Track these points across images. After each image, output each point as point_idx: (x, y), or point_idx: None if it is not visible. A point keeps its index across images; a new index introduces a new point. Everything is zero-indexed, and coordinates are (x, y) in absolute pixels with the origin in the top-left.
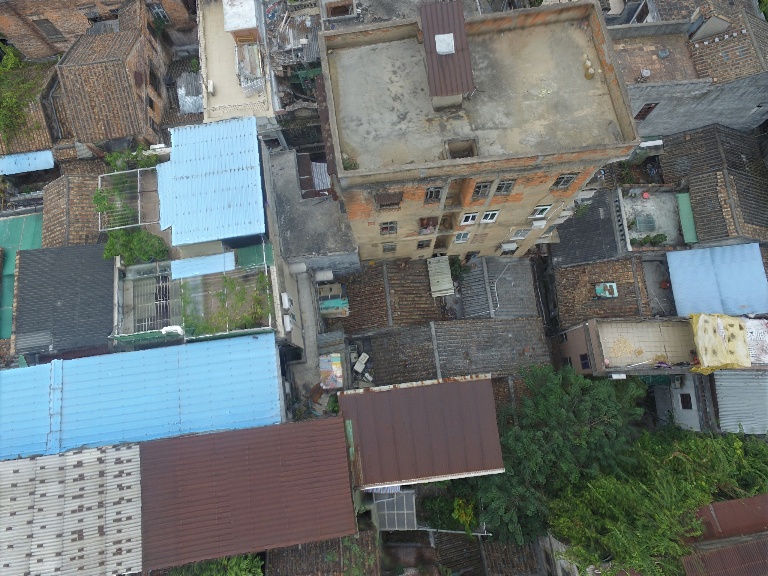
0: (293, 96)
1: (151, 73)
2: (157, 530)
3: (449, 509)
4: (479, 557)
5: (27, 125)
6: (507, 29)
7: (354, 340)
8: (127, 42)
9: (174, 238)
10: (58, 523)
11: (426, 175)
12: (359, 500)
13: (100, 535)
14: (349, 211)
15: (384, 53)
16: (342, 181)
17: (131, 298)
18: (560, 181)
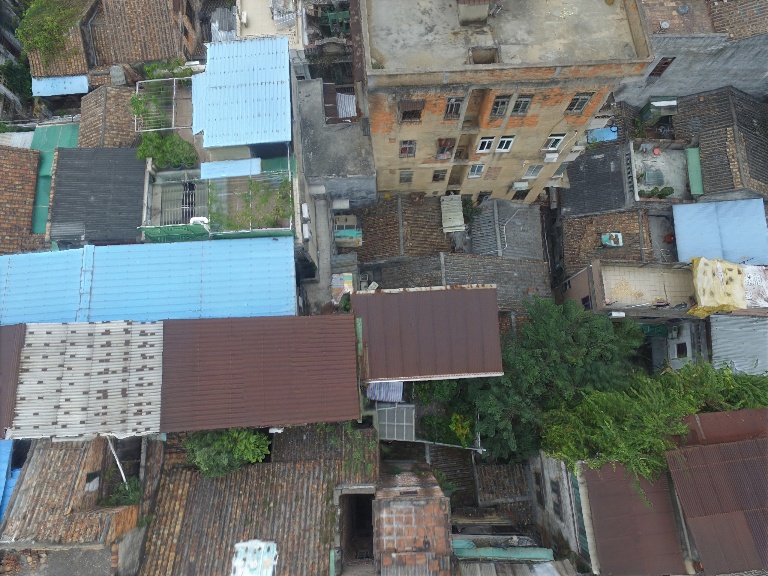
0: (321, 38)
1: (188, 4)
2: (175, 397)
3: (446, 426)
4: (472, 479)
5: (65, 49)
6: None
7: (365, 269)
8: None
9: (205, 141)
10: (85, 382)
11: (449, 81)
12: (362, 405)
13: (123, 396)
14: (373, 121)
15: None
16: (370, 81)
17: (159, 202)
18: (575, 103)
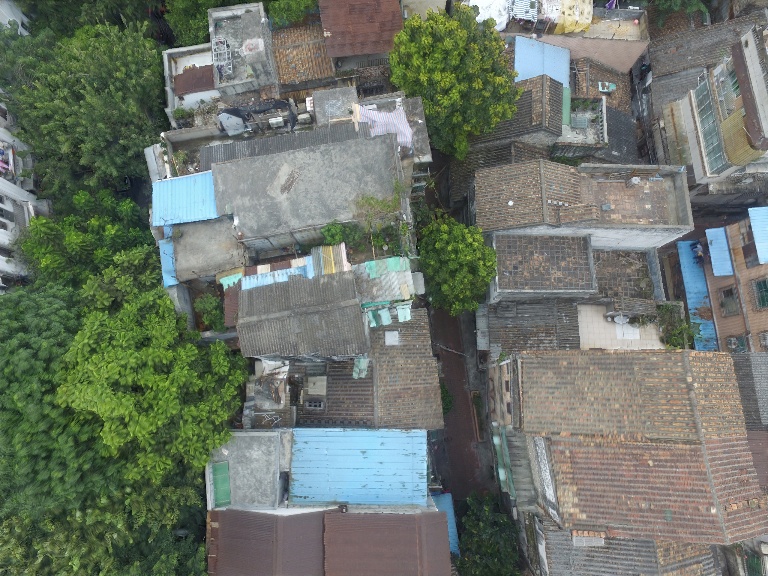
0: None
1: None
2: None
3: None
4: None
5: None
6: None
7: None
8: None
9: None
10: None
11: None
12: None
13: None
14: None
15: None
16: None
17: None
18: None
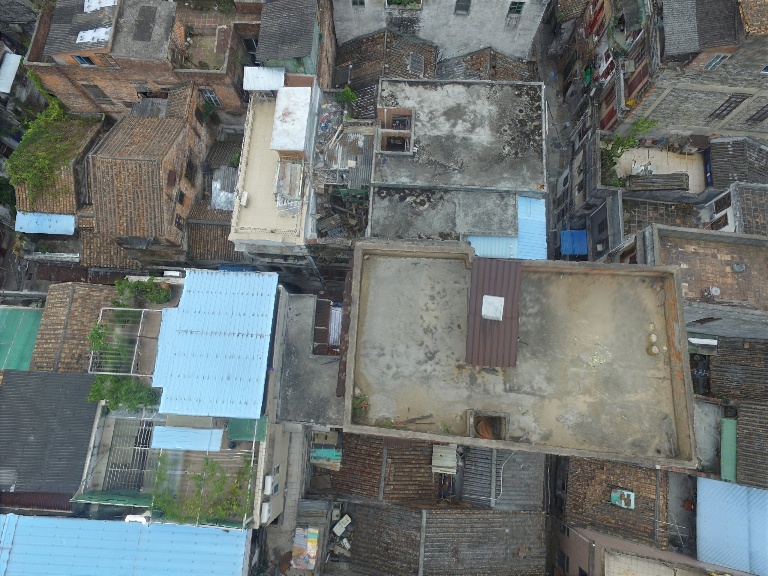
0: (331, 209)
1: (188, 165)
2: None
3: None
4: None
5: (55, 187)
6: (568, 272)
7: None
8: (168, 136)
9: (162, 403)
10: None
11: None
12: None
13: None
14: None
15: (425, 271)
16: None
17: (110, 437)
18: None
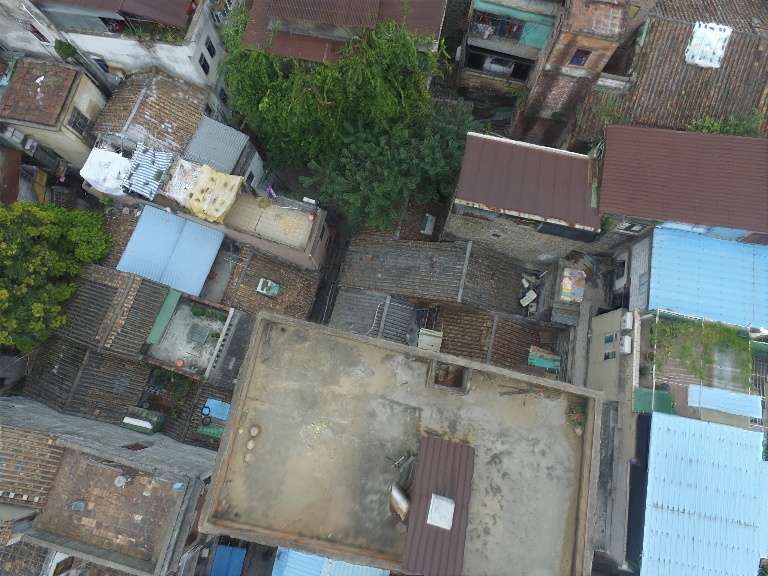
0: None
1: None
2: None
3: None
4: None
5: None
6: (322, 540)
7: None
8: None
9: (760, 443)
10: None
11: None
12: None
13: None
14: None
15: (492, 569)
16: None
17: None
18: None
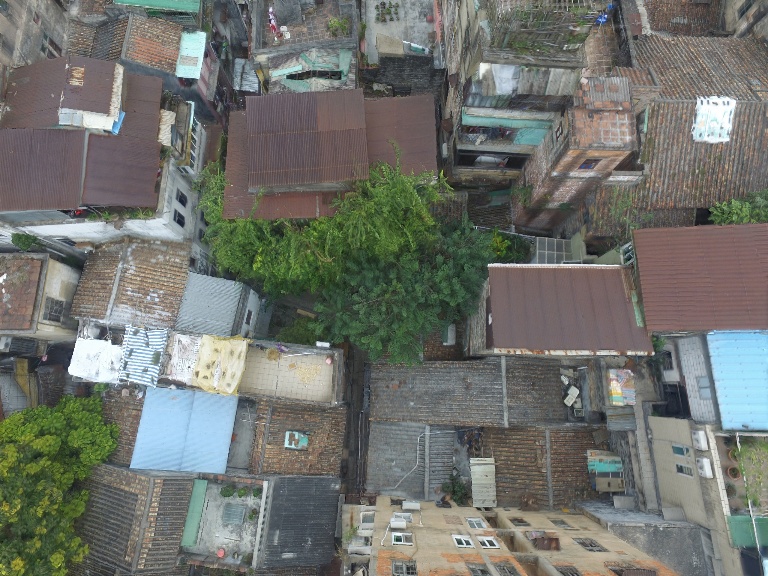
0: None
1: None
2: None
3: None
4: None
5: None
6: None
7: None
8: None
9: None
10: None
11: None
12: None
13: None
14: None
15: None
16: None
17: None
18: (410, 570)
